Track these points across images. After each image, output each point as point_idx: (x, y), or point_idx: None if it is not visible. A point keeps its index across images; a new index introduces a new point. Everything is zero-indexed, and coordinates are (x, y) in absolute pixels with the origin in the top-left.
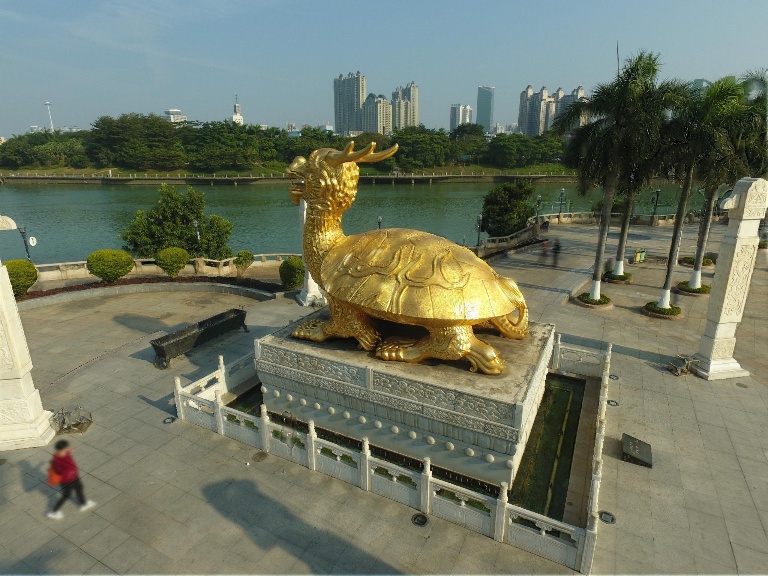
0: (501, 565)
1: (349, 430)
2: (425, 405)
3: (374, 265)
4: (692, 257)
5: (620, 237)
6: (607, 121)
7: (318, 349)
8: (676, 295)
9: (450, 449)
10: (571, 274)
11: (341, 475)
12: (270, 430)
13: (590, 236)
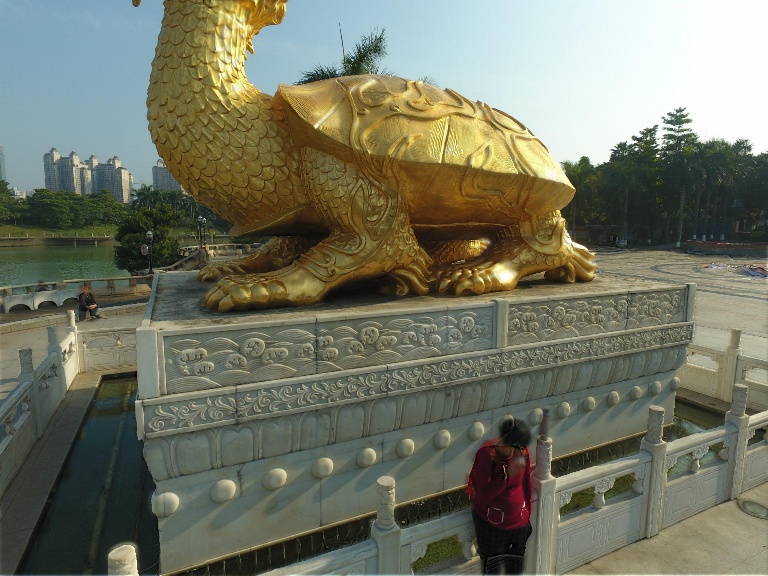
0: None
1: (446, 474)
2: (594, 336)
3: None
4: None
5: None
6: None
7: (342, 309)
8: None
9: (617, 402)
10: None
11: (608, 540)
12: (414, 556)
13: None
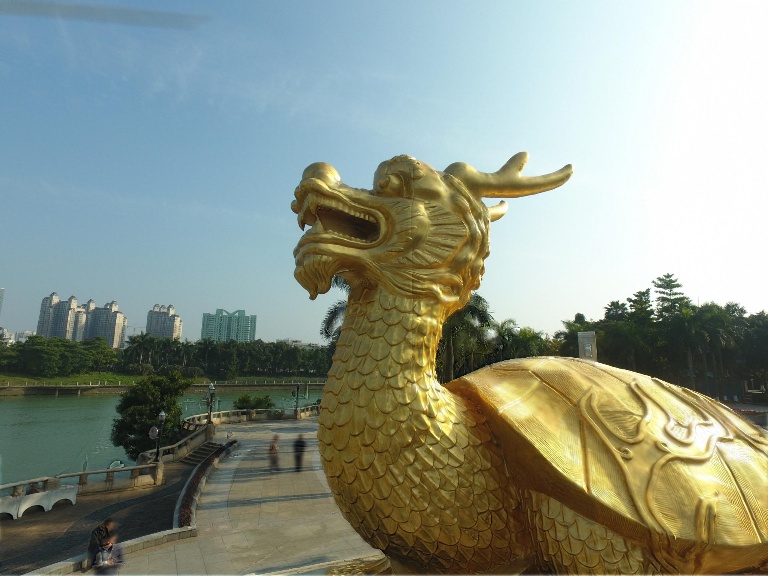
0: None
1: None
2: None
3: None
4: None
5: None
6: None
7: None
8: None
9: None
10: None
11: None
12: None
13: (263, 433)
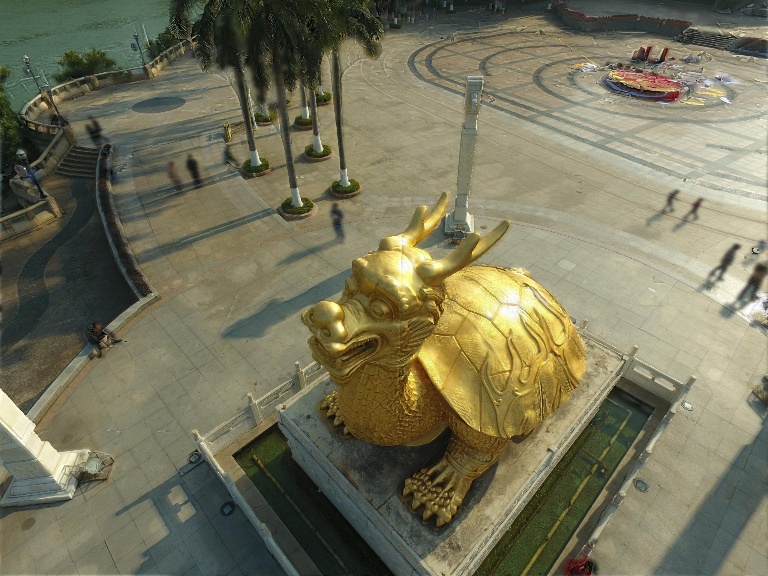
0: (678, 448)
1: None
2: None
3: (531, 362)
4: (260, 114)
5: (246, 125)
6: (253, 1)
7: (490, 496)
8: (317, 164)
9: None
10: (227, 186)
11: None
12: None
13: (127, 118)
